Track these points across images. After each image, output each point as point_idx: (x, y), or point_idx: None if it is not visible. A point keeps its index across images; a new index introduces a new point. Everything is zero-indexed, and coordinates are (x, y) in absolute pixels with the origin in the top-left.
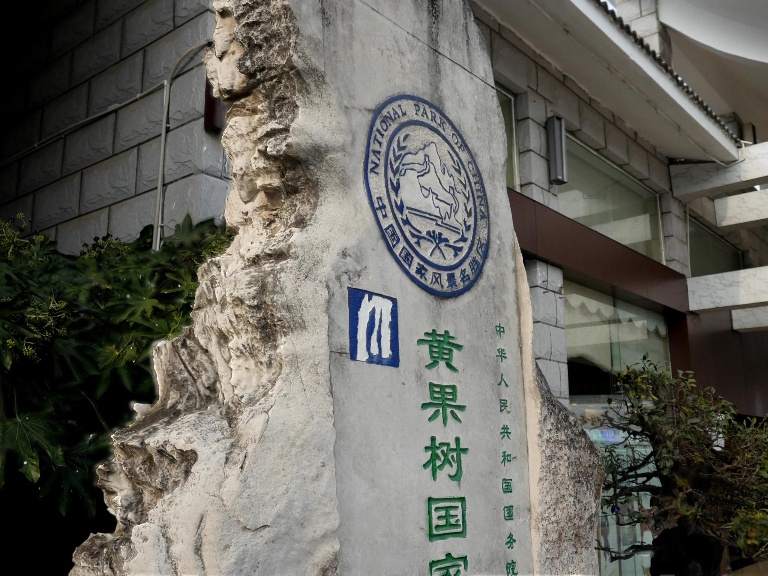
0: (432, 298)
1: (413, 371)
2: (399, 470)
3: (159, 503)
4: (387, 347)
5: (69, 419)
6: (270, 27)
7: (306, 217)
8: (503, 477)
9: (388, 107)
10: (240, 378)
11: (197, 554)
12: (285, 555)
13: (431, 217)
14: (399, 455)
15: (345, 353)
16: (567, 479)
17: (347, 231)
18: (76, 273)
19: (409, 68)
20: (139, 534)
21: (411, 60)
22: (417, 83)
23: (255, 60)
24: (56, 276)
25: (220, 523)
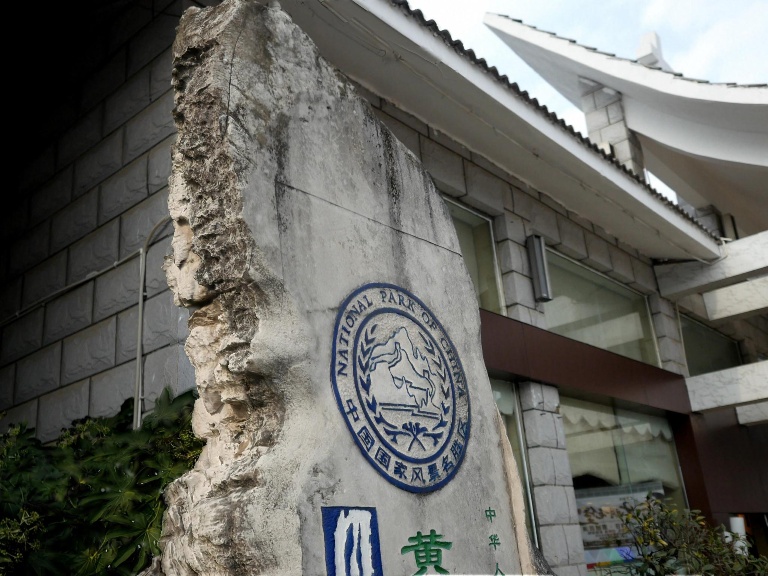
0: (414, 497)
1: None
2: None
3: None
4: (368, 565)
5: None
6: (226, 239)
7: (273, 434)
8: None
9: (353, 301)
10: None
11: None
12: None
13: (406, 408)
14: None
15: None
16: None
17: (317, 444)
18: (48, 468)
19: (372, 255)
20: None
21: (374, 246)
22: (382, 269)
23: (212, 273)
24: (27, 474)
25: None
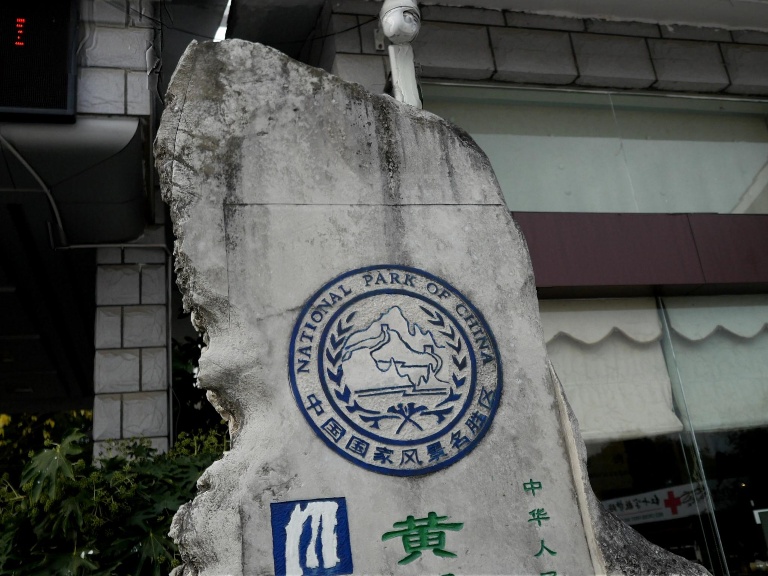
0: (404, 480)
1: (378, 572)
2: None
3: None
4: (332, 555)
5: None
6: None
7: (234, 439)
8: None
9: (324, 294)
10: None
11: None
12: None
13: (395, 390)
14: None
15: (269, 575)
16: None
17: (270, 444)
18: None
19: (354, 241)
20: None
21: (357, 232)
22: (367, 252)
23: None
24: None
25: None
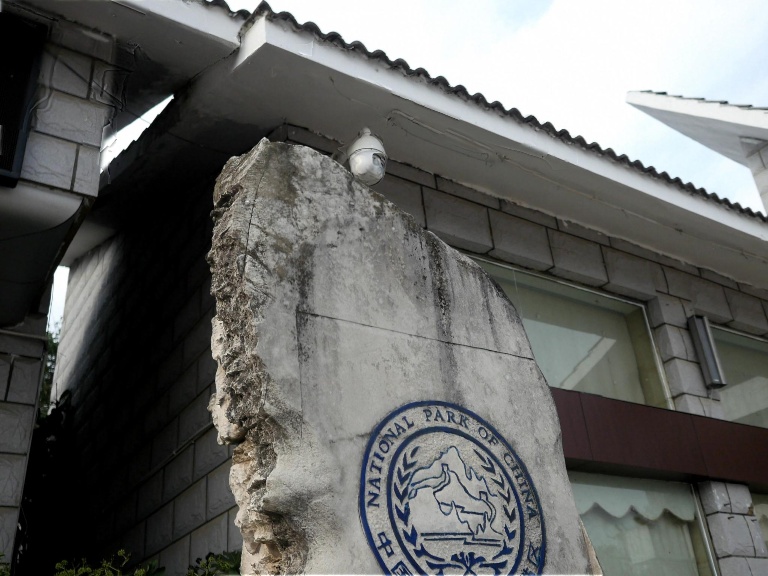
0: None
1: None
2: None
3: None
4: None
5: None
6: (246, 376)
7: (295, 575)
8: None
9: (389, 424)
10: None
11: None
12: None
13: (457, 537)
14: None
15: None
16: None
17: None
18: None
19: (414, 372)
20: None
21: (416, 363)
22: (426, 386)
23: (237, 410)
24: None
25: None
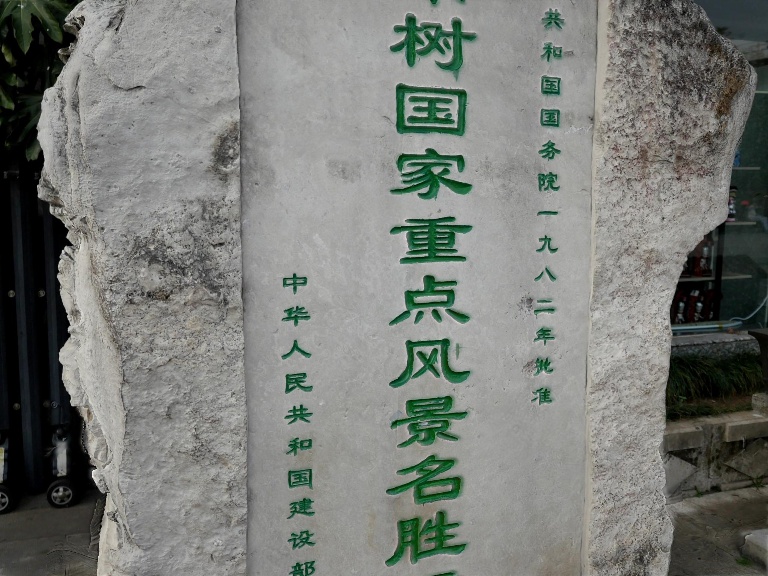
0: None
1: None
2: (348, 48)
3: None
4: None
5: None
6: None
7: None
8: (543, 74)
9: None
10: None
11: (74, 110)
12: (170, 118)
13: None
14: (349, 32)
15: None
16: (660, 83)
17: None
18: None
19: None
20: None
21: None
22: None
23: None
24: None
25: (88, 80)
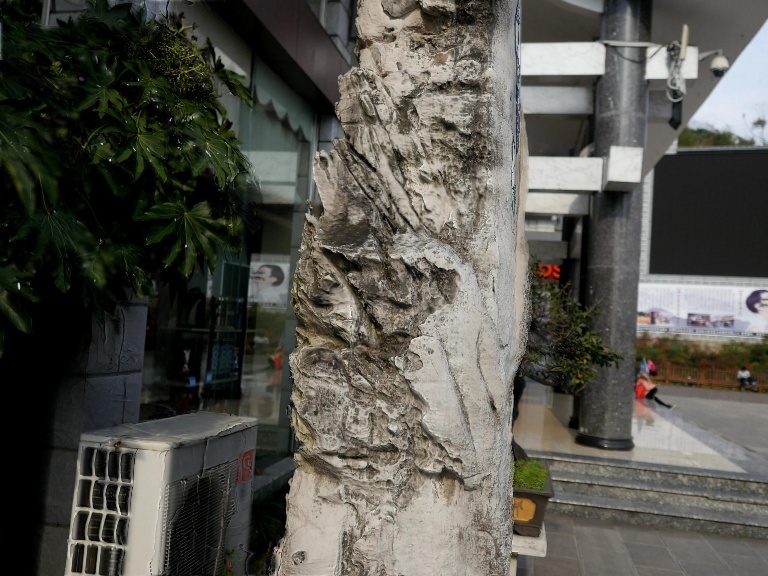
0: None
1: None
2: None
3: (431, 318)
4: None
5: (76, 218)
6: None
7: (485, 53)
8: None
9: None
10: (435, 204)
11: (478, 367)
12: None
13: None
14: None
15: None
16: (526, 324)
17: (510, 75)
18: (2, 34)
19: None
20: (422, 346)
21: None
22: None
23: None
24: None
25: (495, 340)
